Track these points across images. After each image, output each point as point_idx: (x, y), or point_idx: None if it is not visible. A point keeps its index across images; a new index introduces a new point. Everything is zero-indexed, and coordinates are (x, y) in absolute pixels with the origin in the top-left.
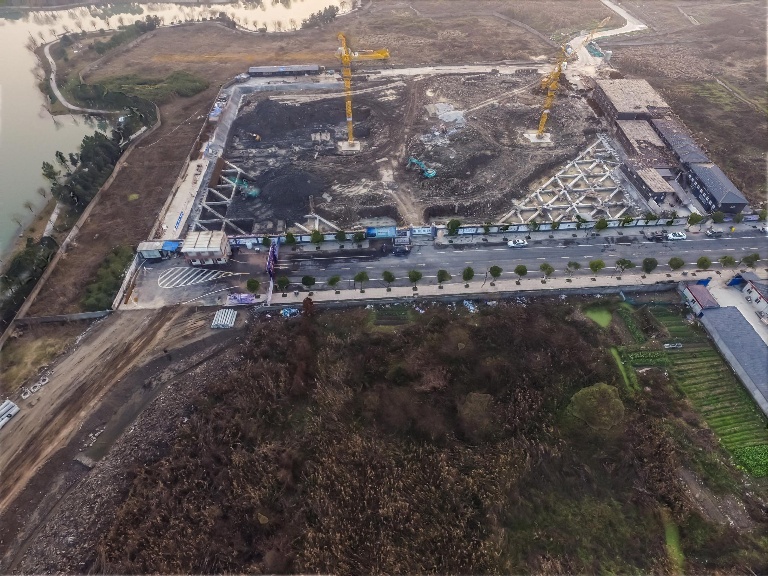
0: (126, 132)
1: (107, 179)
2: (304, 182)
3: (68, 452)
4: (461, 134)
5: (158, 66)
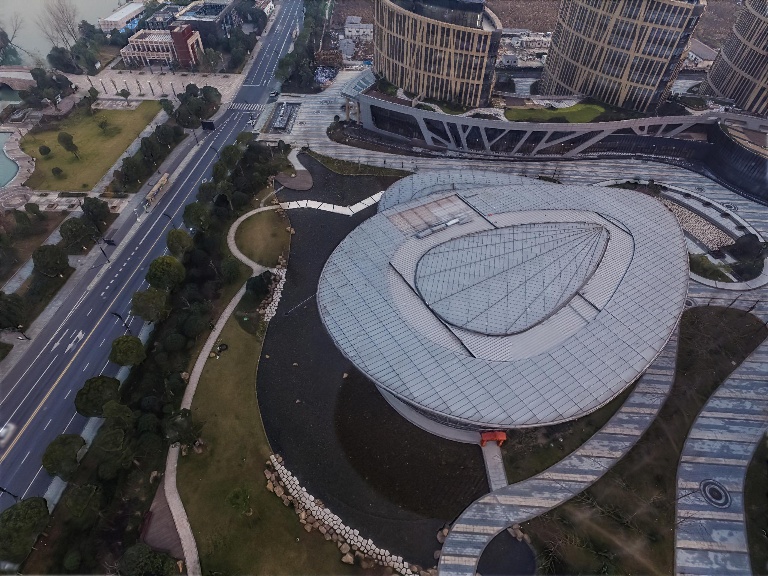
0: None
1: None
2: None
3: None
4: None
5: None
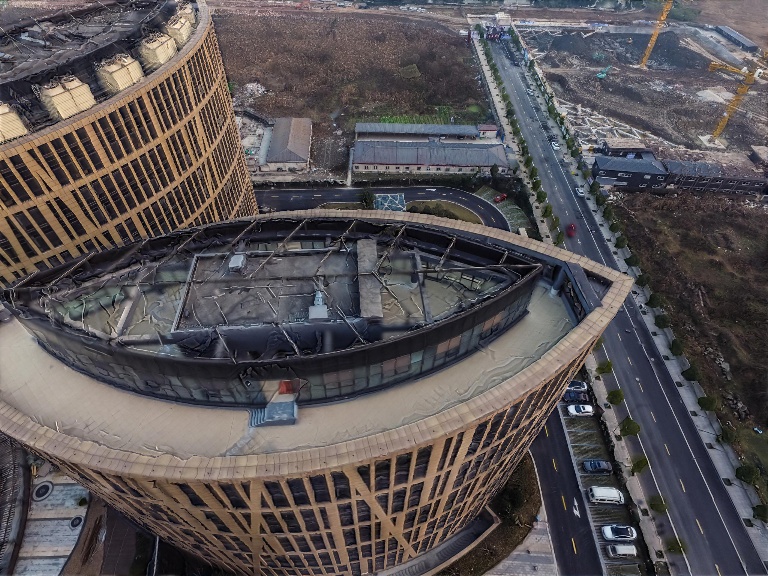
0: (601, 4)
1: (556, 8)
2: (569, 41)
3: (409, 21)
4: (670, 91)
5: (705, 6)
